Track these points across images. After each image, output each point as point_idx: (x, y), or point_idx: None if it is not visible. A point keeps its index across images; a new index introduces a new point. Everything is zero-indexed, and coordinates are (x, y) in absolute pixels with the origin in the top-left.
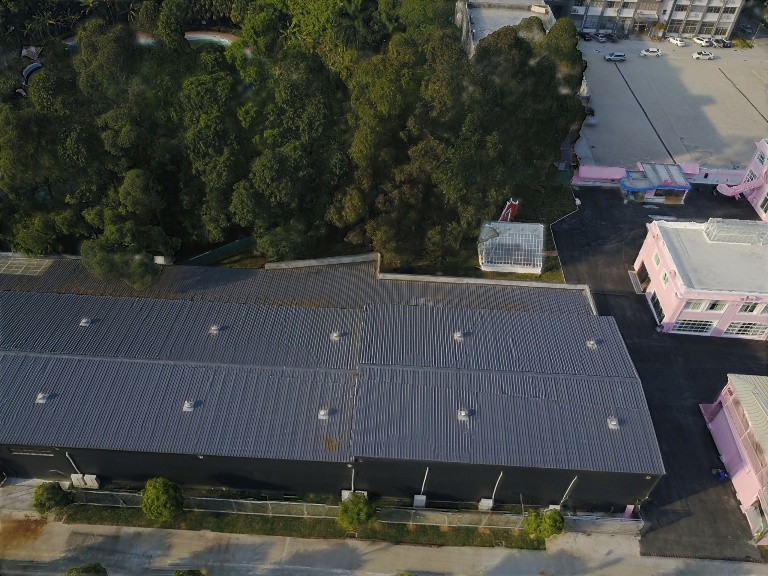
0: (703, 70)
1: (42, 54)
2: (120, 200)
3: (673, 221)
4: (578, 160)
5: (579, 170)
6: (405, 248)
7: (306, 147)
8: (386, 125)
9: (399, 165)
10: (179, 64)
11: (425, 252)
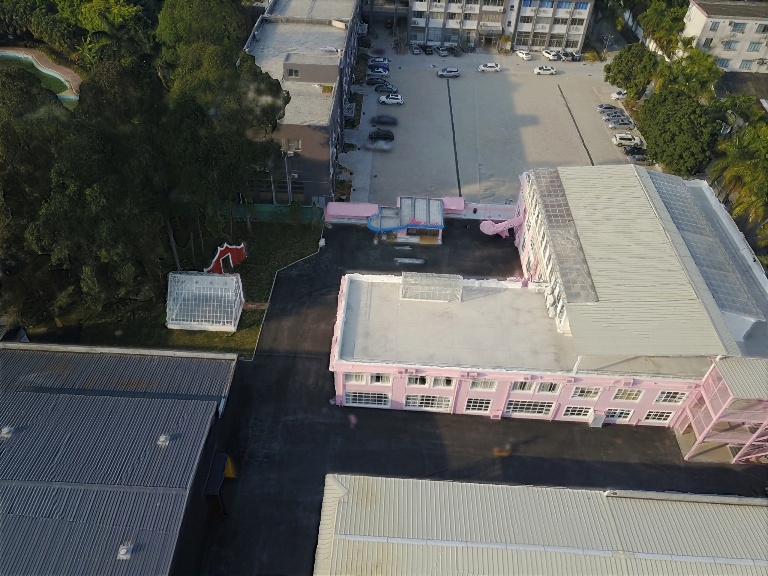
0: (539, 87)
1: None
2: None
3: None
4: (350, 192)
5: (327, 207)
6: None
7: None
8: None
9: None
10: None
11: (115, 306)
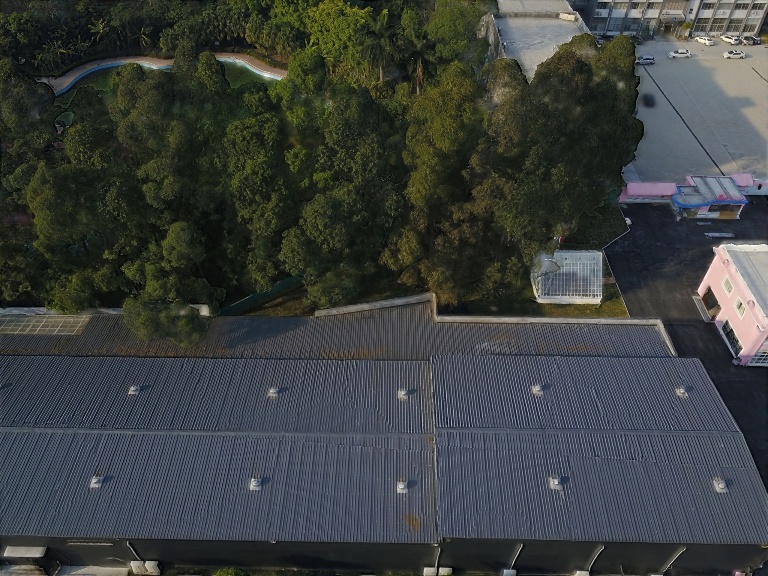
0: (736, 70)
1: (74, 103)
2: (164, 255)
3: (733, 239)
4: None
5: (627, 188)
6: (454, 281)
7: (359, 189)
8: (444, 162)
9: (456, 202)
10: (220, 107)
11: (476, 285)
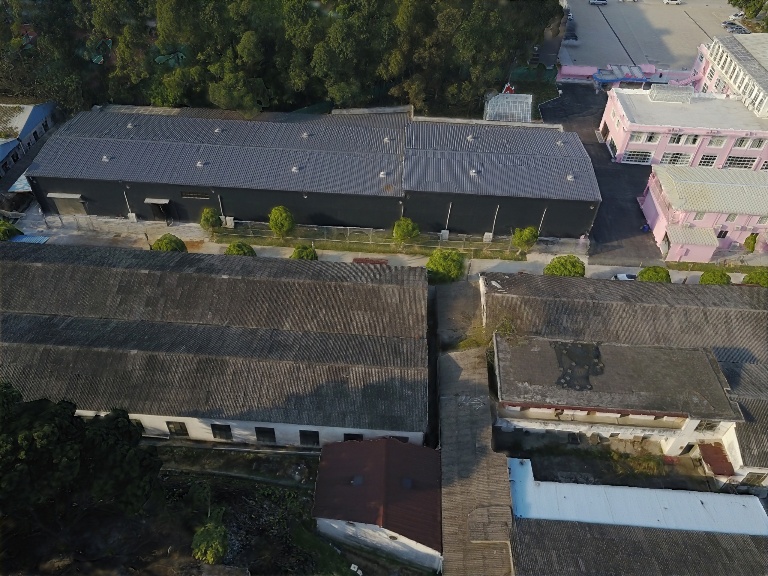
0: (671, 12)
1: None
2: (238, 53)
3: None
4: None
5: (562, 69)
6: None
7: (365, 19)
8: (421, 3)
9: (428, 36)
10: None
11: None
